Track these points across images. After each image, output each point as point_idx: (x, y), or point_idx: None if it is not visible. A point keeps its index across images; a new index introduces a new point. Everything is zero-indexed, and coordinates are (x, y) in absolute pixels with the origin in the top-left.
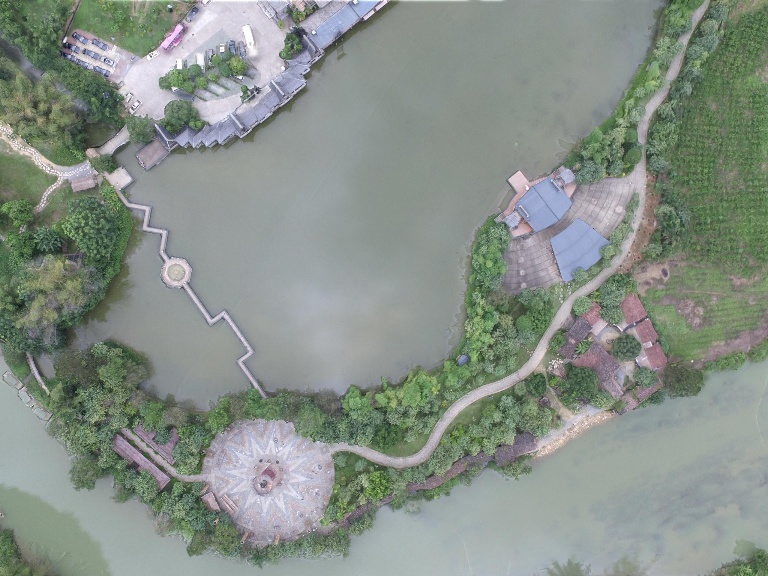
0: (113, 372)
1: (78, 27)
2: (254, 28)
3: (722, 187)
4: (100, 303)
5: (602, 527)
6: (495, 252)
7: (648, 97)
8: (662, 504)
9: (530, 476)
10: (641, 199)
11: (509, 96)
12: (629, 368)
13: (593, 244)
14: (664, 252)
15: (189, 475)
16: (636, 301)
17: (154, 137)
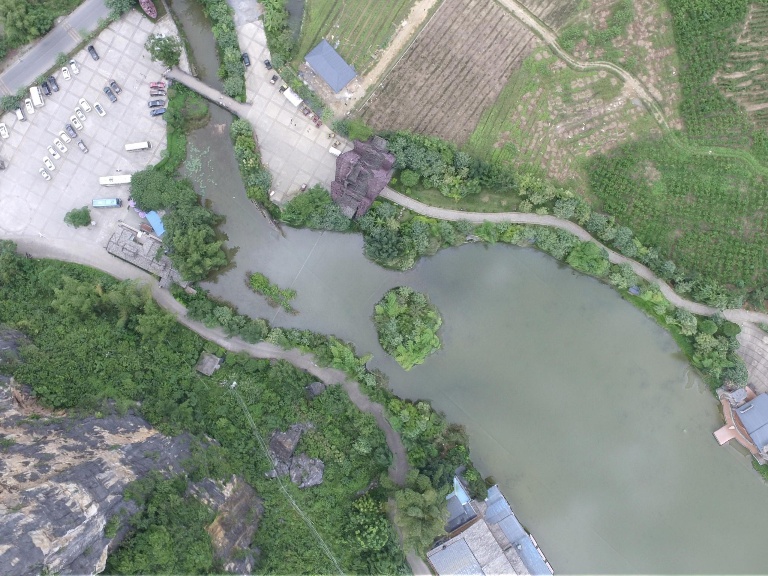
0: None
1: None
2: None
3: (760, 236)
4: None
5: None
6: None
7: None
8: None
9: None
10: (760, 317)
11: (638, 433)
12: None
13: None
14: None
15: None
16: None
17: None
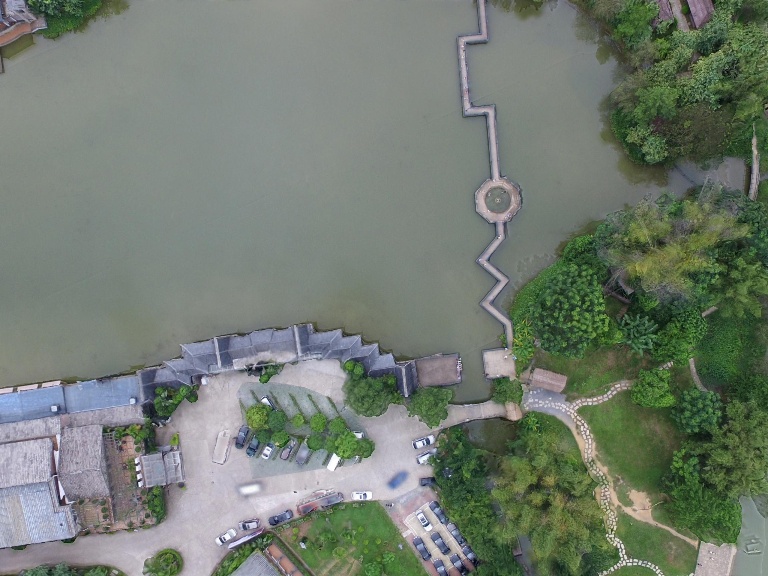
0: None
1: None
2: None
3: None
4: None
5: None
6: None
7: None
8: None
9: None
10: None
11: None
12: None
13: None
14: None
15: None
16: None
17: (422, 388)
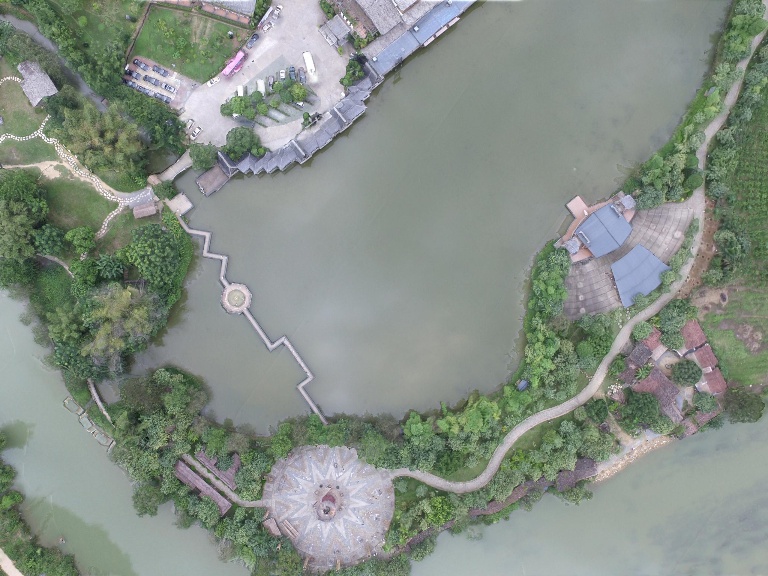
0: (178, 399)
1: (139, 54)
2: (314, 54)
3: None
4: (161, 329)
5: (660, 551)
6: (556, 278)
7: (707, 122)
8: (720, 528)
9: (590, 501)
10: (700, 224)
11: (567, 121)
12: (688, 393)
13: (653, 270)
14: (725, 278)
15: (251, 501)
16: (696, 326)
17: (215, 163)
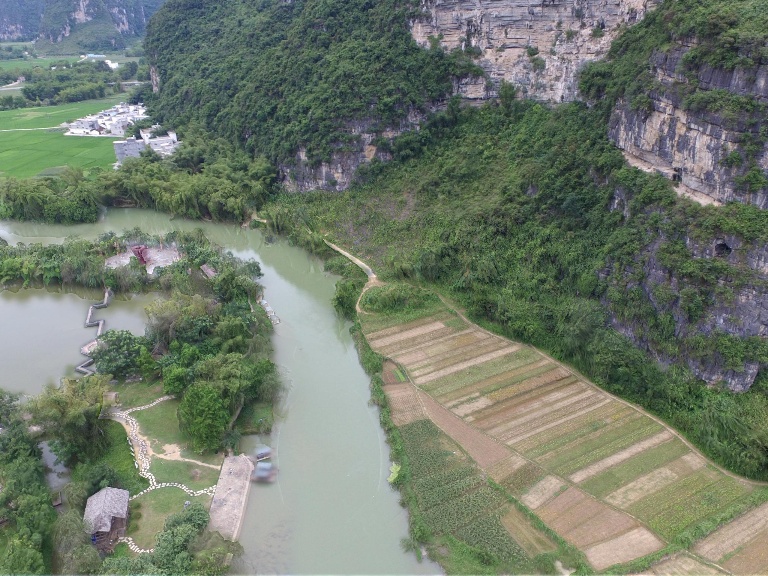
0: None
1: None
2: None
3: None
4: None
5: None
6: None
7: None
8: None
9: None
10: None
11: None
12: None
13: None
14: None
15: None
16: None
17: None
